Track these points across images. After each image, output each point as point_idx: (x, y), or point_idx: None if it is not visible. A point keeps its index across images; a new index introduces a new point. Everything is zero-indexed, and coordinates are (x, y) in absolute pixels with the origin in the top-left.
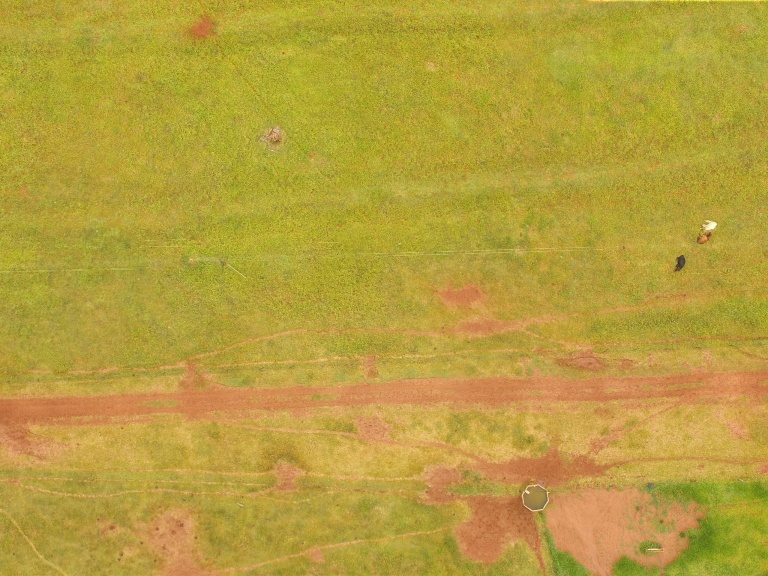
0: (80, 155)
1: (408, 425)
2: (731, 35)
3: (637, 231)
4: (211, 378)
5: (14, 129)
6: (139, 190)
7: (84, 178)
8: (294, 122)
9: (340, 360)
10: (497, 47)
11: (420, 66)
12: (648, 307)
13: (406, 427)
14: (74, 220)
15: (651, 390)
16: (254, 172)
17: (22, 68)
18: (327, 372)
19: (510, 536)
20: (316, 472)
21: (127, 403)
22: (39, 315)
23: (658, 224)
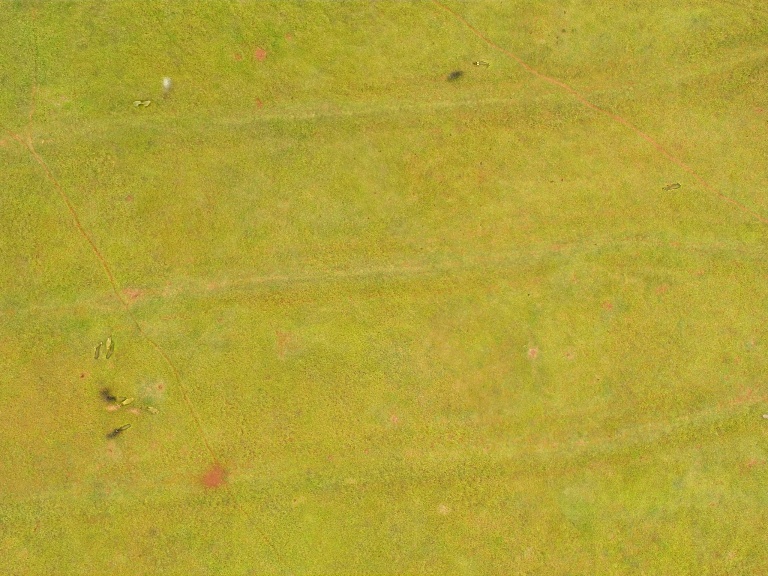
0: None
1: None
2: (741, 470)
3: None
4: None
5: None
6: None
7: None
8: (308, 572)
9: None
10: (508, 487)
11: (432, 512)
12: None
13: None
14: None
15: None
16: None
17: (35, 526)
18: None
19: None
20: None
21: None
22: None
23: None
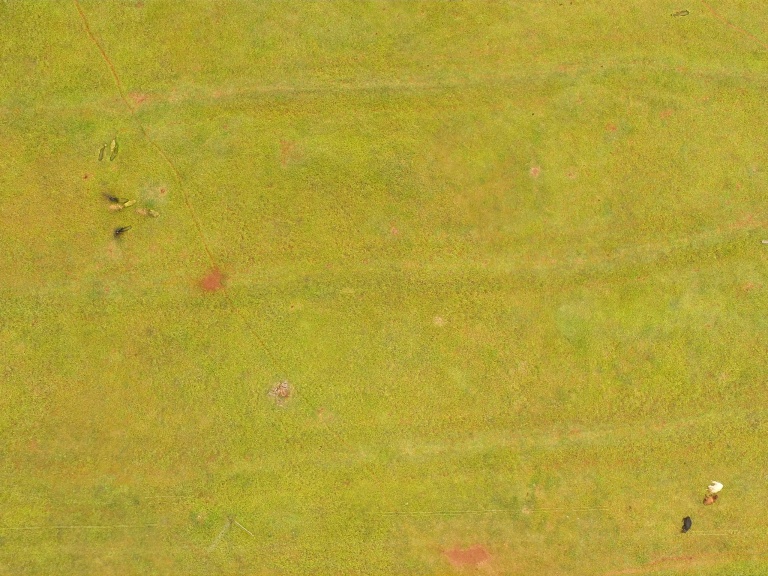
0: (90, 409)
1: None
2: (738, 292)
3: (643, 491)
4: None
5: (25, 383)
6: (148, 445)
7: (94, 433)
8: (302, 377)
9: None
10: (504, 302)
11: (428, 322)
12: (654, 569)
13: None
14: (83, 477)
15: None
16: (262, 428)
17: (33, 321)
18: None
19: None
20: None
21: None
22: (48, 572)
23: (664, 484)
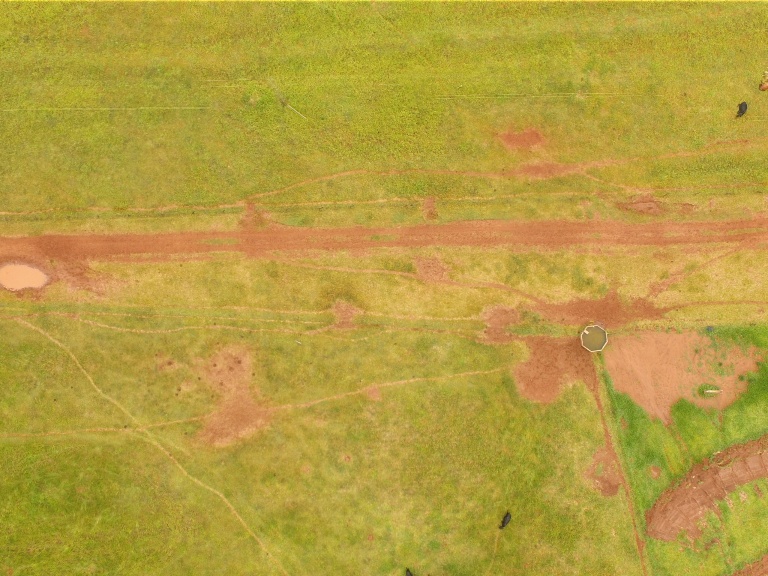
0: None
1: (467, 266)
2: None
3: (699, 78)
4: (270, 217)
5: None
6: (200, 31)
7: (146, 18)
8: None
9: (399, 201)
10: None
11: None
12: (709, 152)
13: (465, 268)
14: (136, 59)
15: (711, 235)
16: (315, 14)
17: None
18: (386, 213)
19: (568, 377)
20: (374, 311)
21: (186, 241)
22: (100, 152)
23: (720, 71)
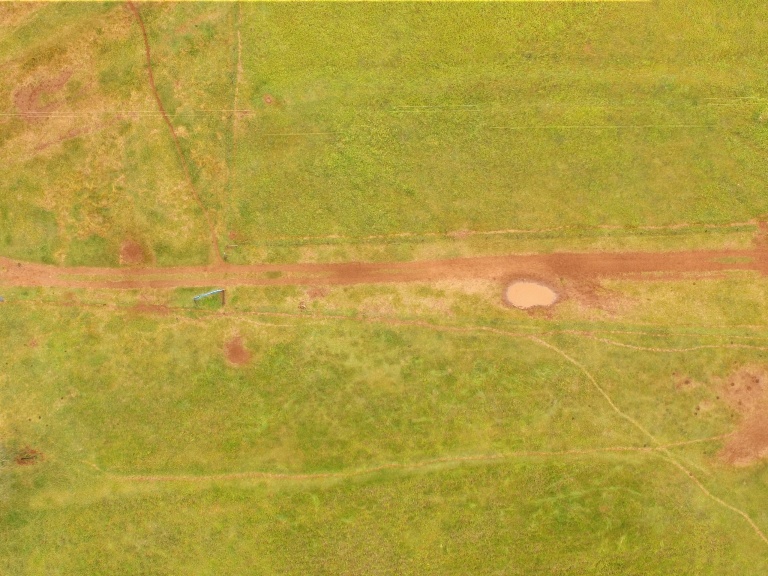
0: (643, 13)
1: None
2: None
3: None
4: None
5: None
6: (704, 49)
7: (649, 36)
8: None
9: None
10: None
11: None
12: None
13: None
14: (643, 76)
15: None
16: None
17: None
18: None
19: None
20: None
21: (698, 259)
22: (609, 170)
23: None
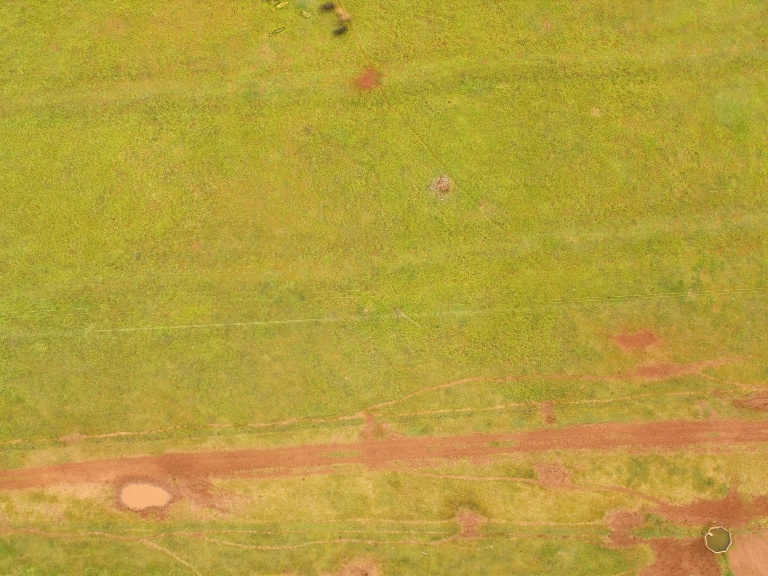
0: (251, 208)
1: (588, 470)
2: None
3: None
4: (390, 427)
5: (185, 184)
6: (311, 242)
7: (256, 231)
8: (463, 171)
9: (517, 407)
10: (661, 91)
11: (586, 112)
12: None
13: (586, 472)
14: (249, 274)
15: None
16: (425, 221)
17: (190, 123)
18: (505, 419)
19: None
20: (498, 519)
21: (307, 454)
22: (217, 369)
23: None
